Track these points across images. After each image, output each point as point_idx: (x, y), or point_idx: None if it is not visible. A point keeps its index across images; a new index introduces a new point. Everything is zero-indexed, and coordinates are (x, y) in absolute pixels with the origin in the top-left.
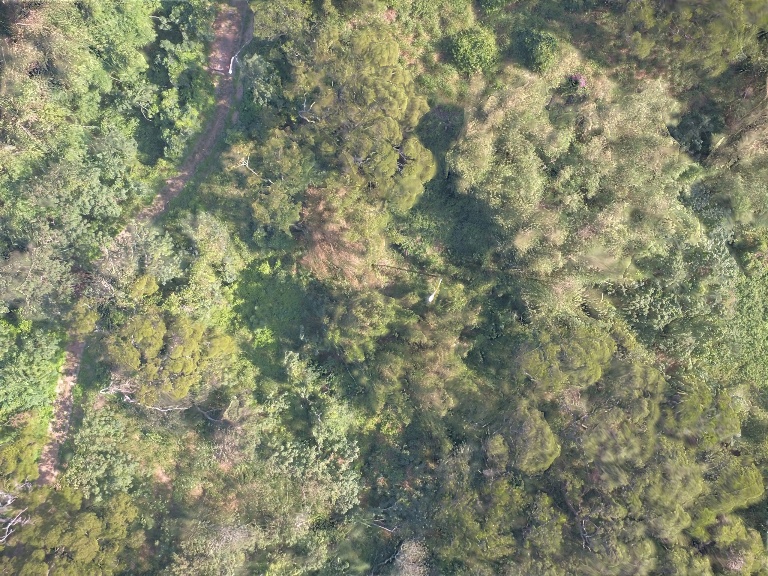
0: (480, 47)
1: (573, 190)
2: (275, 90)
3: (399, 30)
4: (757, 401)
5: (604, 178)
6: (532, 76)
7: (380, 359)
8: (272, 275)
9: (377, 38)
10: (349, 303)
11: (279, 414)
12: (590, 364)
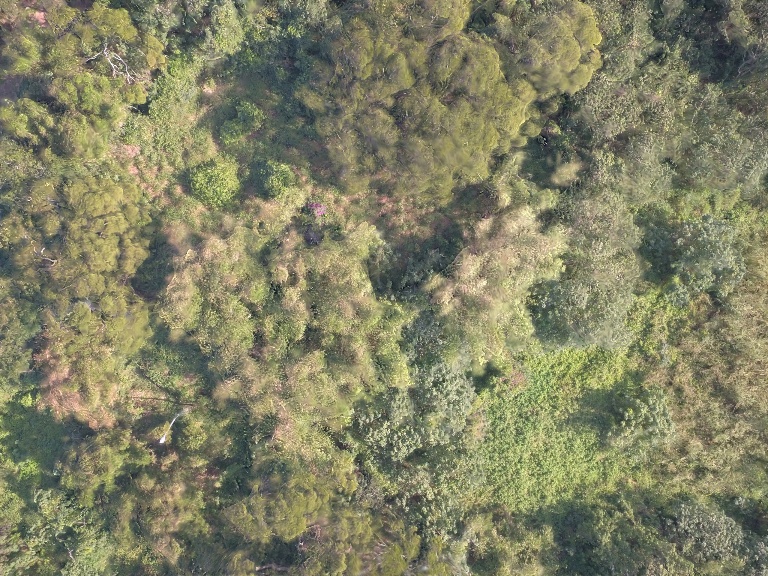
0: (215, 181)
1: (283, 336)
2: (16, 232)
3: (143, 163)
4: (504, 528)
5: (311, 324)
6: (273, 205)
7: (113, 503)
8: (35, 407)
9: (98, 184)
10: (80, 449)
11: (43, 546)
12: (290, 517)
